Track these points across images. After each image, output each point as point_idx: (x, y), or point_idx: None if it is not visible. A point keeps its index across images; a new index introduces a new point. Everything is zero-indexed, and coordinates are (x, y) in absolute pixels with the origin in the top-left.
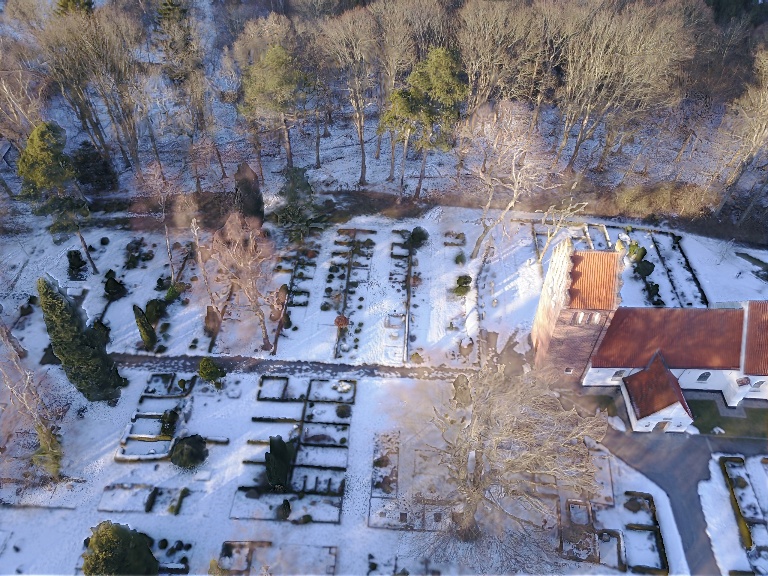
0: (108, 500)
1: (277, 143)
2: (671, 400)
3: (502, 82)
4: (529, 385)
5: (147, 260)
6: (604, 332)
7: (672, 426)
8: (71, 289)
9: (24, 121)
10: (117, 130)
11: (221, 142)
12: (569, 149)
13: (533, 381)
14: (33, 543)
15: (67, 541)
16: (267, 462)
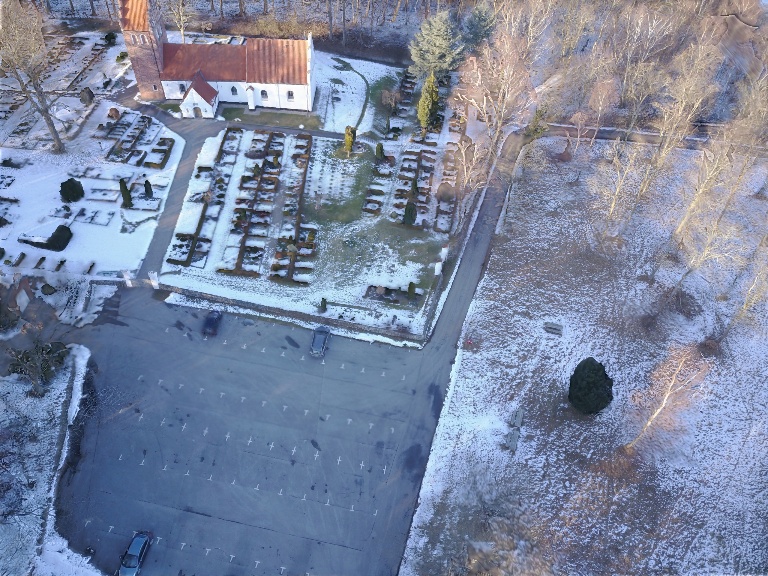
0: None
1: (57, 3)
2: None
3: None
4: (7, 3)
5: None
6: (156, 52)
7: (203, 112)
8: None
9: None
10: None
11: None
12: (256, 5)
13: (9, 1)
14: None
15: None
16: None
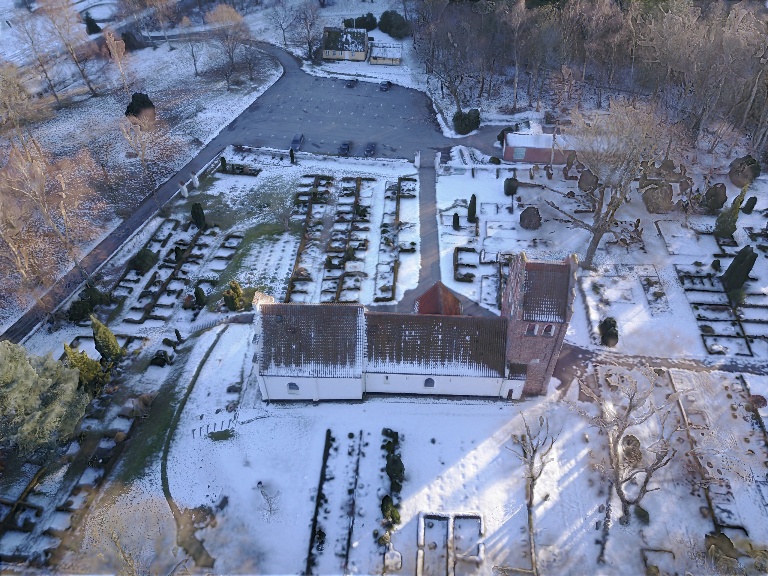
0: None
1: None
2: None
3: None
4: None
5: None
6: None
7: None
8: None
9: None
10: None
11: None
12: None
13: None
14: None
15: None
16: None
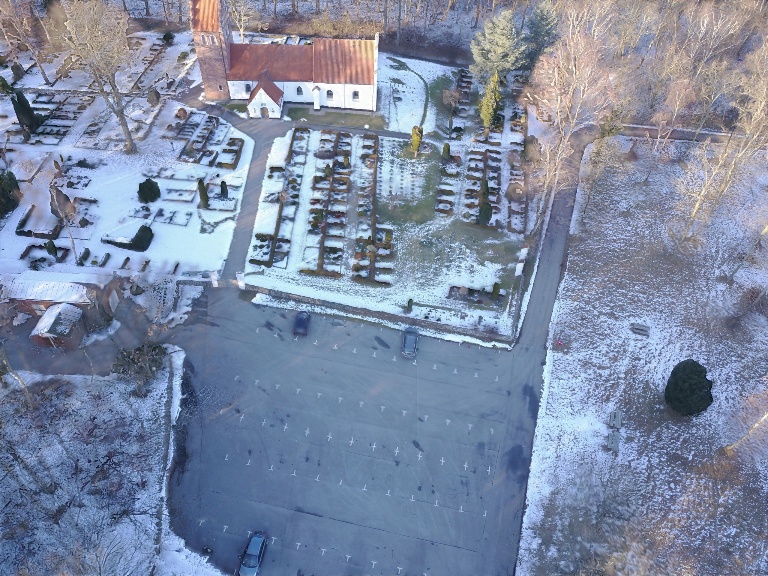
0: None
1: (107, 2)
2: (259, 89)
3: None
4: (93, 4)
5: None
6: (224, 52)
7: (270, 112)
8: None
9: None
10: None
11: (67, 2)
12: (306, 4)
13: (95, 2)
14: None
15: None
16: None
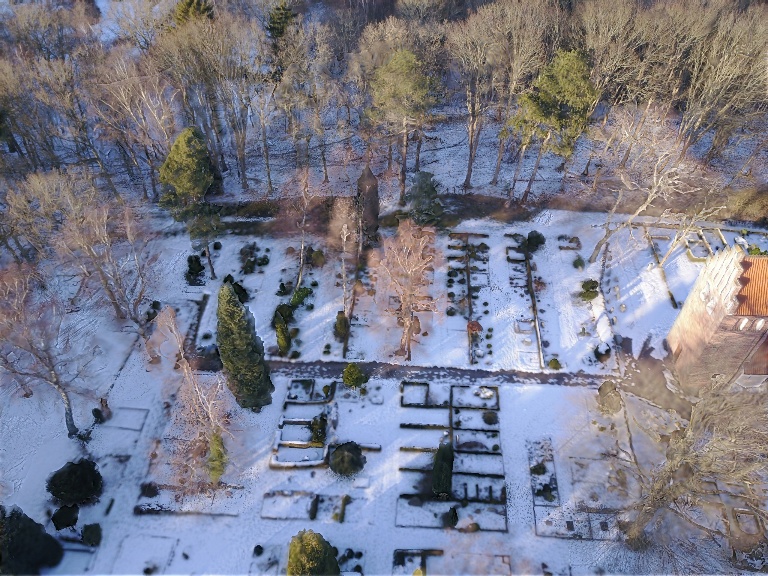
0: (270, 507)
1: None
2: None
3: (629, 85)
4: None
5: (263, 265)
6: (764, 338)
7: None
8: (192, 294)
9: (152, 127)
10: (231, 135)
11: (311, 146)
12: None
13: None
14: (201, 550)
15: (235, 548)
16: (438, 470)
